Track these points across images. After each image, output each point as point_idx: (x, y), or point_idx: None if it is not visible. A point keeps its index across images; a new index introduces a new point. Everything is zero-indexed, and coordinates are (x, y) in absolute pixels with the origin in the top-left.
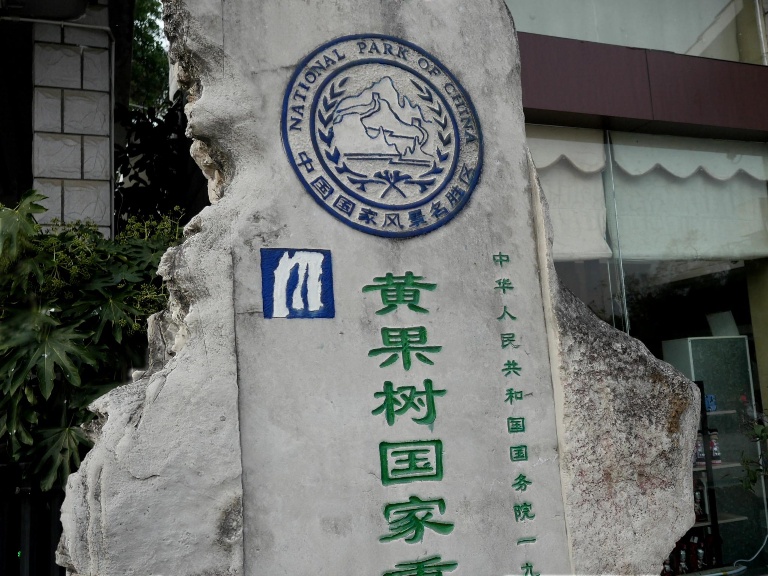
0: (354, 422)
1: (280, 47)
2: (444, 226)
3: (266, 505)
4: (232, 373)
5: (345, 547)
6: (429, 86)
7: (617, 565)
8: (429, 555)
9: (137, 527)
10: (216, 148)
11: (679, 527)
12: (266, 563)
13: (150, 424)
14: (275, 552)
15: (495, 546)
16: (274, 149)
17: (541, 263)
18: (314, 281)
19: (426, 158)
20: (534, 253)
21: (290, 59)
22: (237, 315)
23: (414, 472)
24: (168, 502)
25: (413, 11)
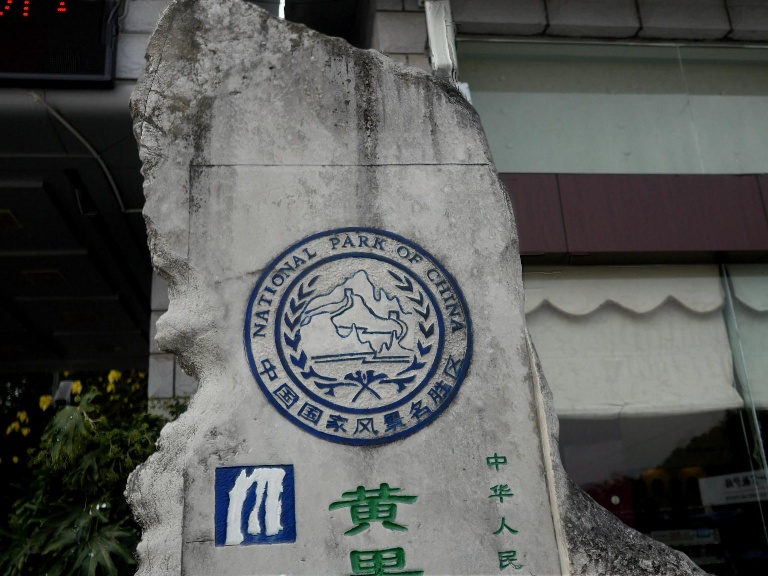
0: None
1: (247, 253)
2: (426, 428)
3: None
4: None
5: None
6: (409, 275)
7: None
8: None
9: None
10: (181, 361)
11: None
12: None
13: None
14: None
15: None
16: (236, 359)
17: (546, 464)
18: (273, 501)
19: (405, 353)
20: (538, 452)
21: (257, 264)
22: (186, 545)
23: None
24: None
25: (392, 199)
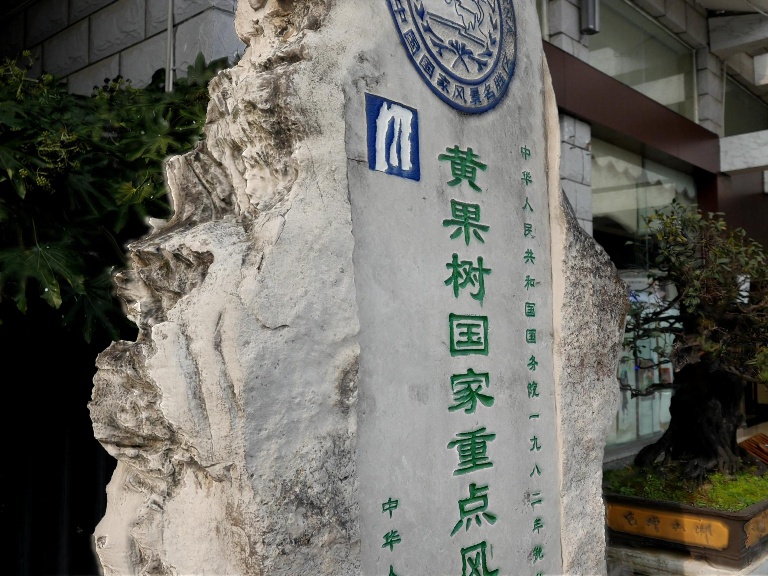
0: (433, 290)
1: None
2: (492, 109)
3: (370, 367)
4: (348, 222)
5: (424, 415)
6: None
7: (583, 439)
8: (479, 425)
9: (270, 382)
10: None
11: (613, 409)
12: (370, 428)
13: (274, 268)
14: (376, 417)
15: (517, 419)
16: None
17: (550, 163)
18: (406, 139)
19: (482, 38)
20: (544, 152)
21: None
22: (347, 160)
23: (471, 345)
24: (295, 356)
25: None
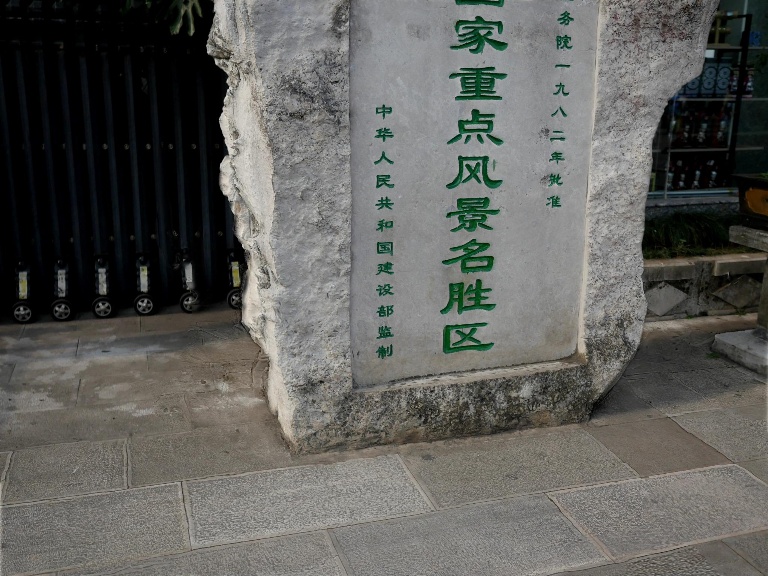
0: None
1: None
2: None
3: (366, 7)
4: None
5: (424, 49)
6: None
7: (631, 94)
8: (486, 64)
9: (273, 9)
10: None
11: (687, 73)
12: (365, 52)
13: None
14: (372, 44)
15: (538, 65)
16: None
17: None
18: None
19: None
20: None
21: None
22: None
23: None
24: None
25: None
